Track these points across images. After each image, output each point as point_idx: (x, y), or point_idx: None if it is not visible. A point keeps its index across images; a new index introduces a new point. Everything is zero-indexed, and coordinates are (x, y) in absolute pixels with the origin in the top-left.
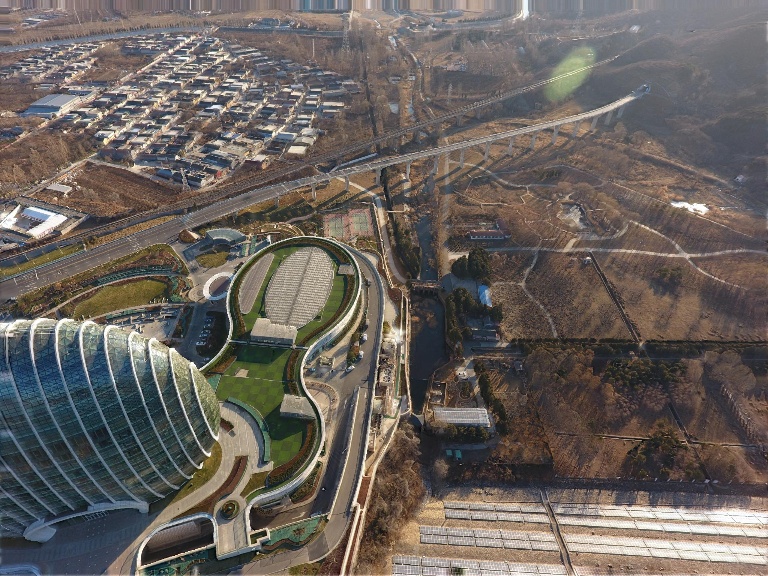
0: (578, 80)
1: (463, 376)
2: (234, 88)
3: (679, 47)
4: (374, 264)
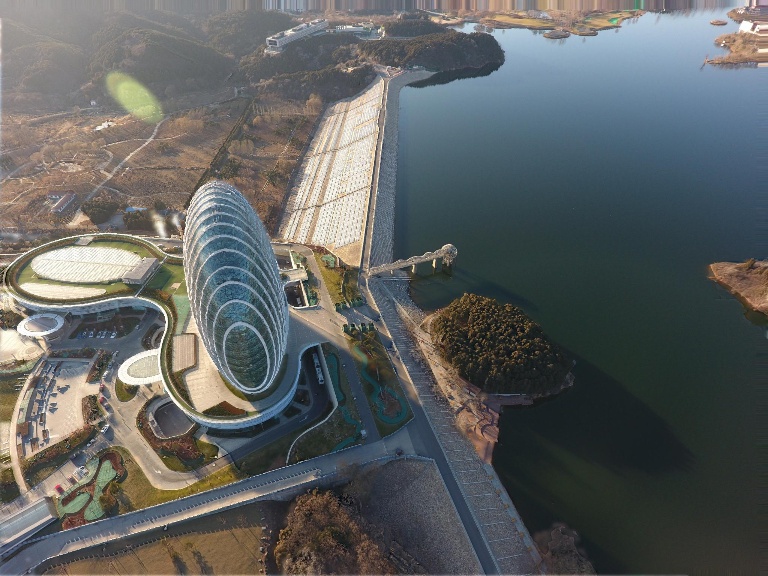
0: None
1: None
2: None
3: None
4: None
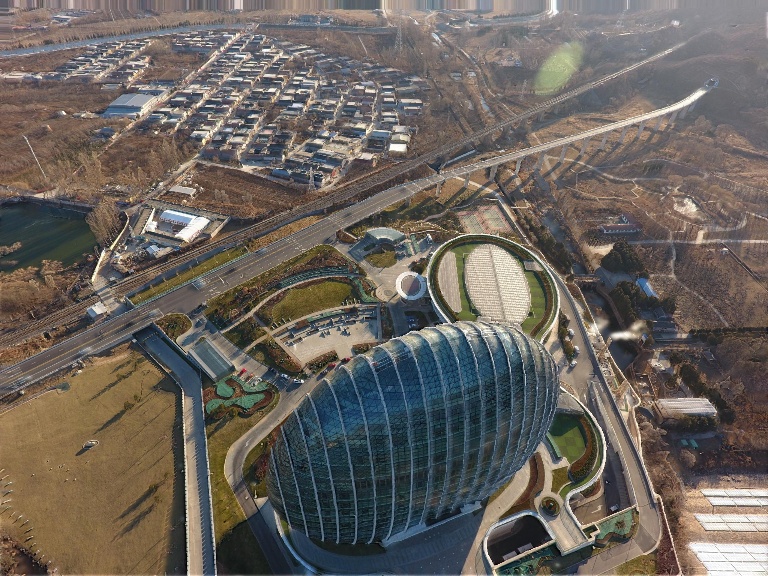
0: (639, 75)
1: (660, 367)
2: (306, 86)
3: (730, 42)
4: None
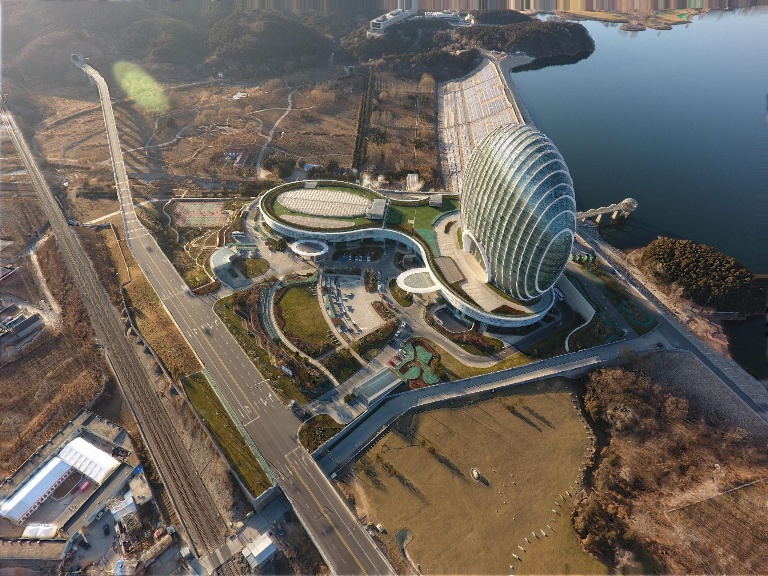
0: (5, 76)
1: None
2: None
3: (19, 24)
4: None
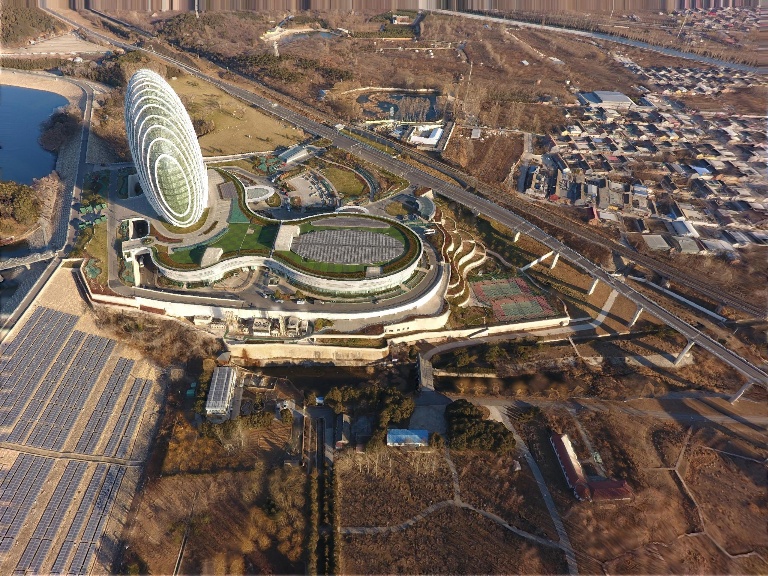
0: None
1: (282, 406)
2: None
3: None
4: (423, 312)
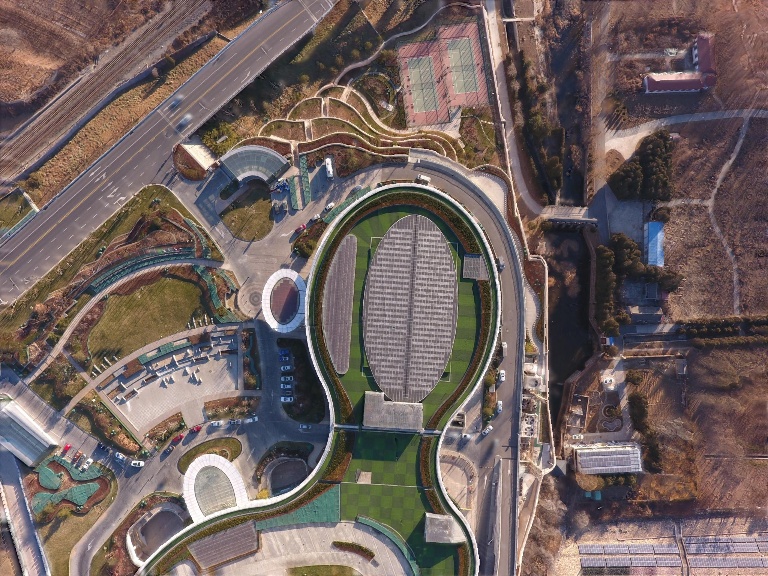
0: None
1: (610, 384)
2: None
3: None
4: (501, 204)
